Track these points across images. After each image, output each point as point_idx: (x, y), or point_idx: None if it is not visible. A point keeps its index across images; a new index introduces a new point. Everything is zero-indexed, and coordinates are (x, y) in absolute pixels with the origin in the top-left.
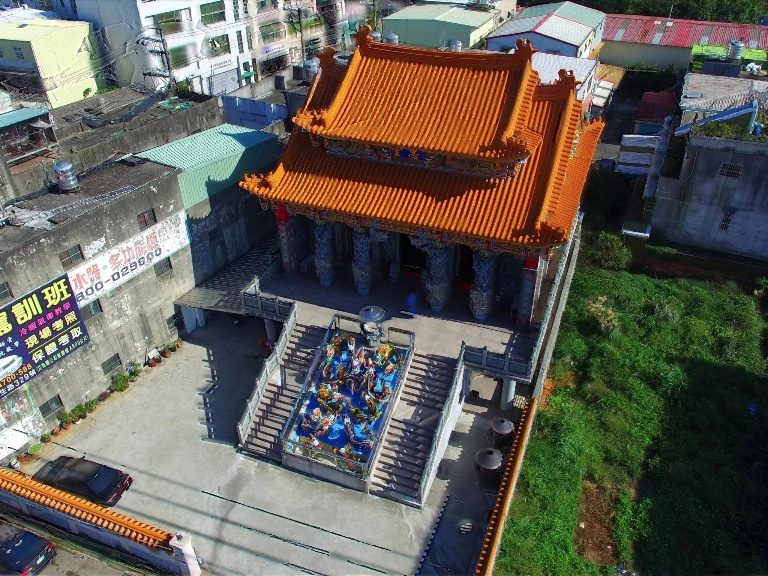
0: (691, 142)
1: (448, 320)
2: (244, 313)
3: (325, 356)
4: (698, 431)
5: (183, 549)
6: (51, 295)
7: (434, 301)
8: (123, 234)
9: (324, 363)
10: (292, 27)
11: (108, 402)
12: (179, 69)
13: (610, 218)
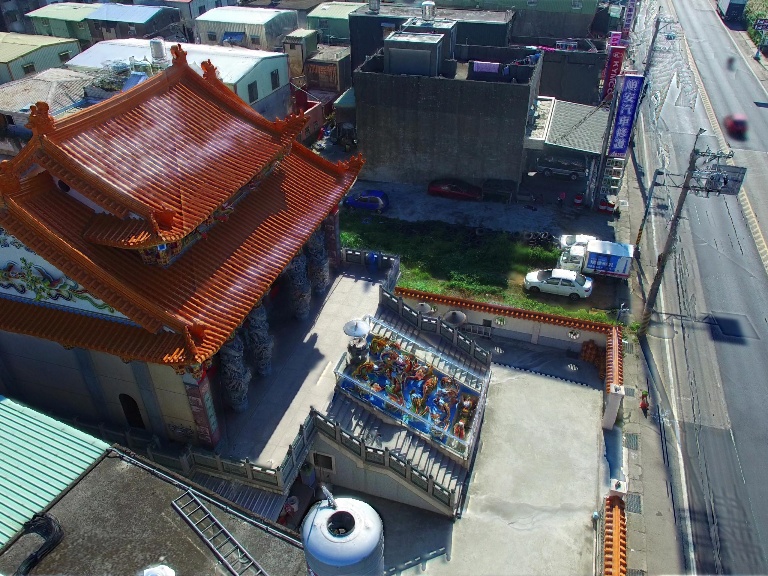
0: None
1: (322, 311)
2: (288, 493)
3: (370, 402)
4: (391, 245)
5: None
6: None
7: (307, 308)
8: None
9: (376, 406)
10: None
11: None
12: None
13: None
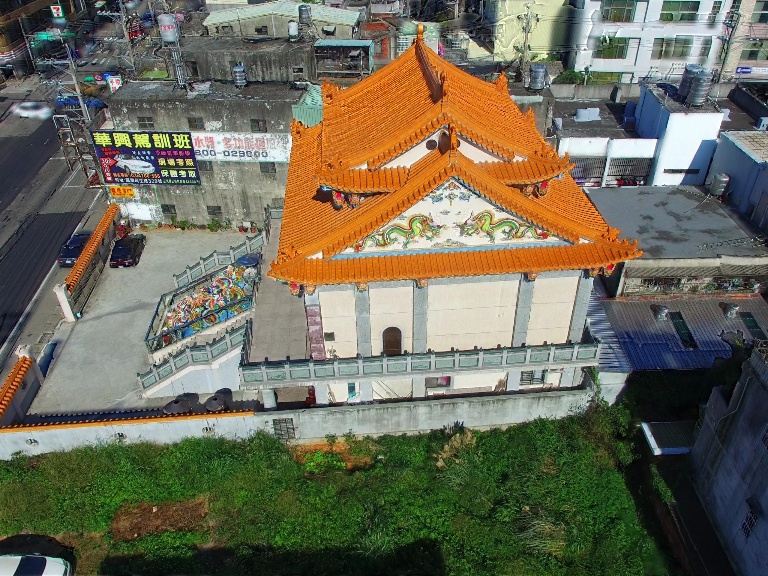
0: (751, 358)
1: None
2: None
3: None
4: None
5: (58, 292)
6: (179, 140)
7: None
8: (237, 127)
9: None
10: (721, 45)
11: (200, 231)
12: (610, 59)
13: (690, 413)
